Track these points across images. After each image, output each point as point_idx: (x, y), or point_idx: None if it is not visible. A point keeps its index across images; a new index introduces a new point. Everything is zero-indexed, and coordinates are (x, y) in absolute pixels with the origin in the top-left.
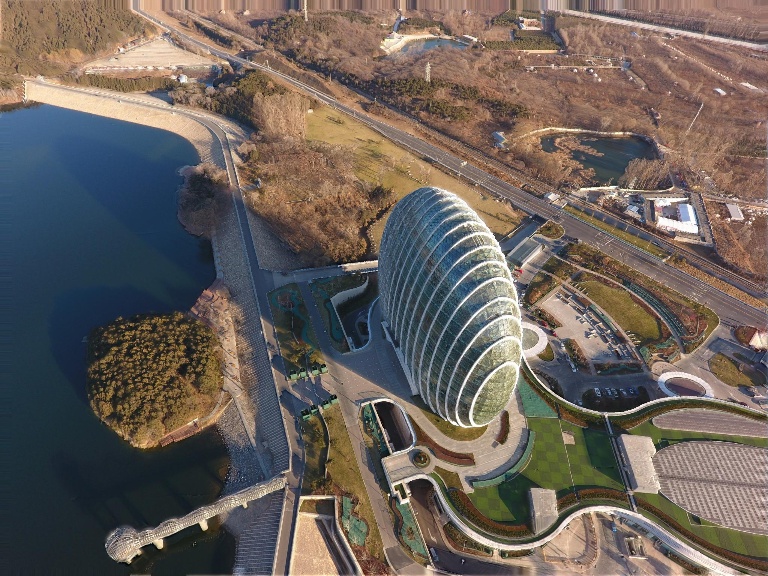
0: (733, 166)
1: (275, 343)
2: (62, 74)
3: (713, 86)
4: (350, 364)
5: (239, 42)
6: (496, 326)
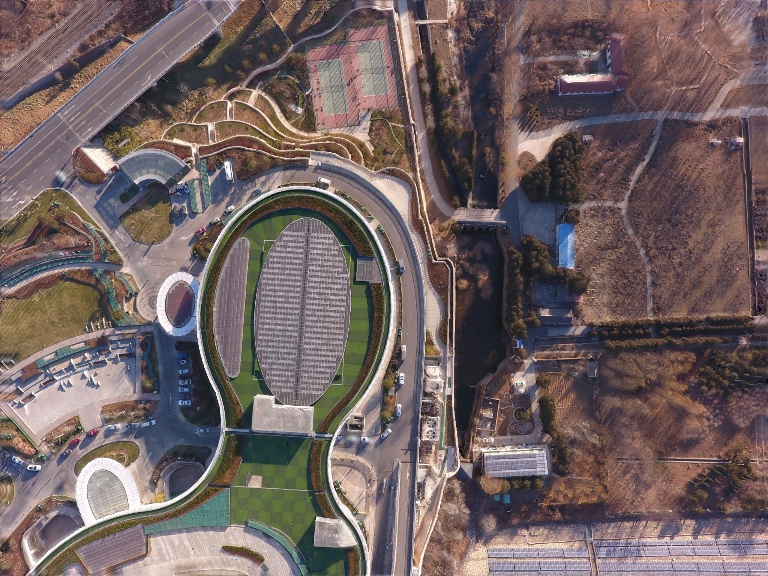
0: None
1: None
2: None
3: None
4: None
5: None
6: None
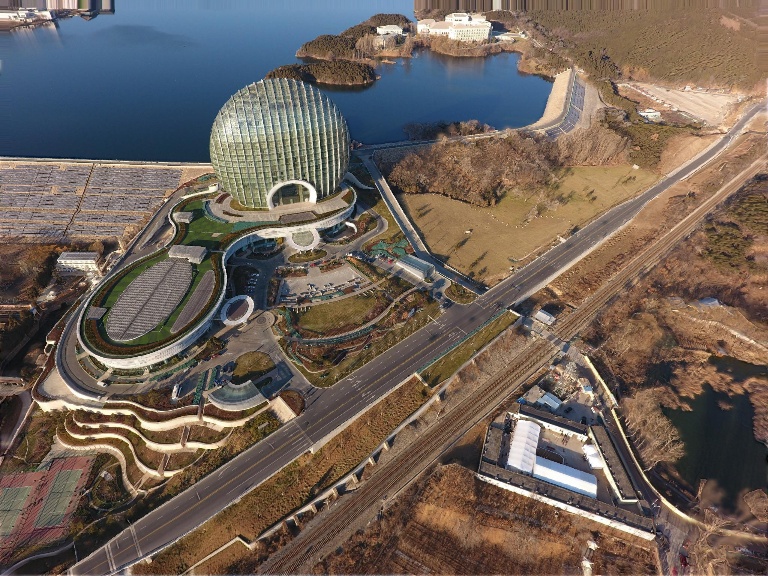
0: None
1: None
2: (595, 75)
3: None
4: None
5: None
6: None
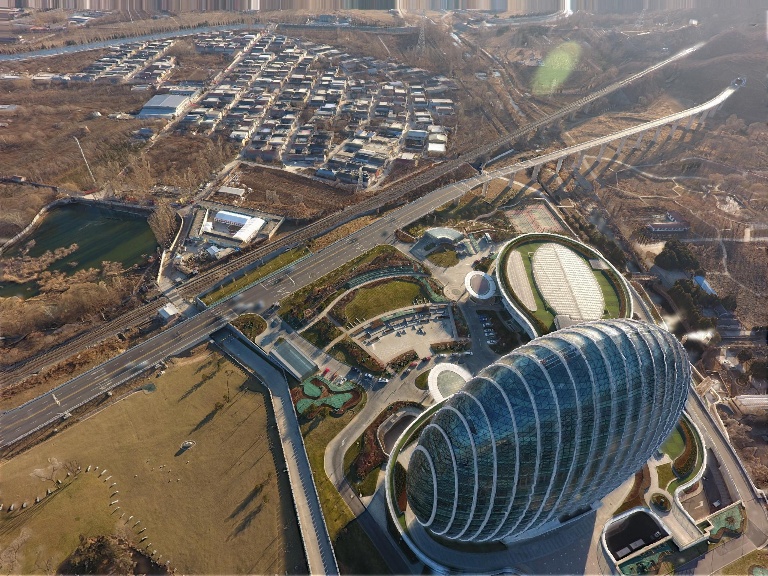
0: (155, 167)
1: None
2: None
3: None
4: None
5: None
6: None
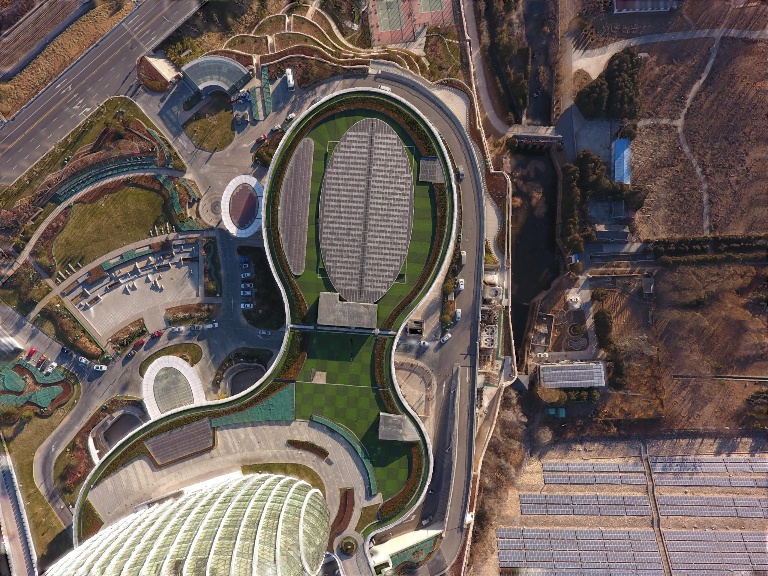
0: None
1: None
2: None
3: None
4: None
5: None
6: None
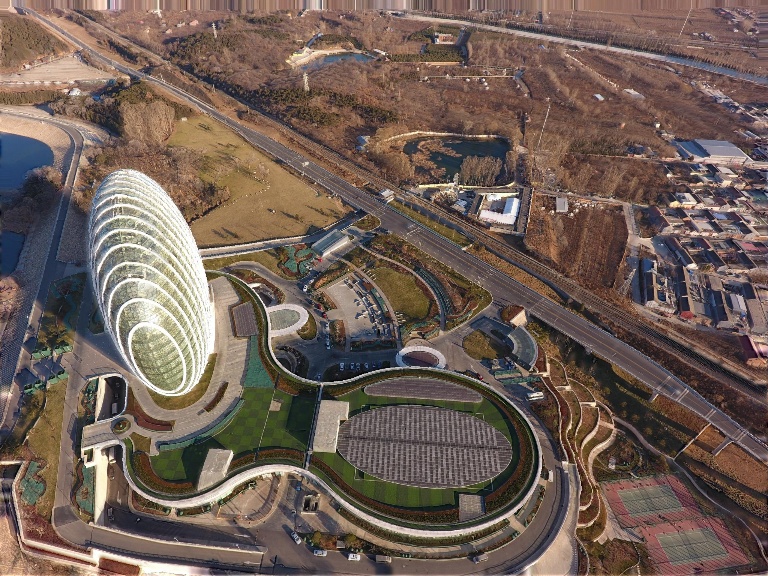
0: (580, 164)
1: (37, 326)
2: None
3: (595, 92)
4: (97, 343)
5: (146, 58)
6: (124, 288)
